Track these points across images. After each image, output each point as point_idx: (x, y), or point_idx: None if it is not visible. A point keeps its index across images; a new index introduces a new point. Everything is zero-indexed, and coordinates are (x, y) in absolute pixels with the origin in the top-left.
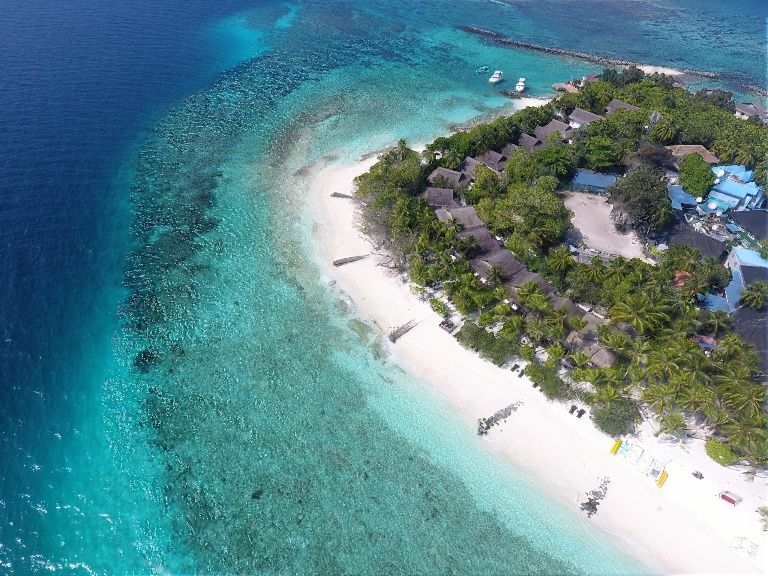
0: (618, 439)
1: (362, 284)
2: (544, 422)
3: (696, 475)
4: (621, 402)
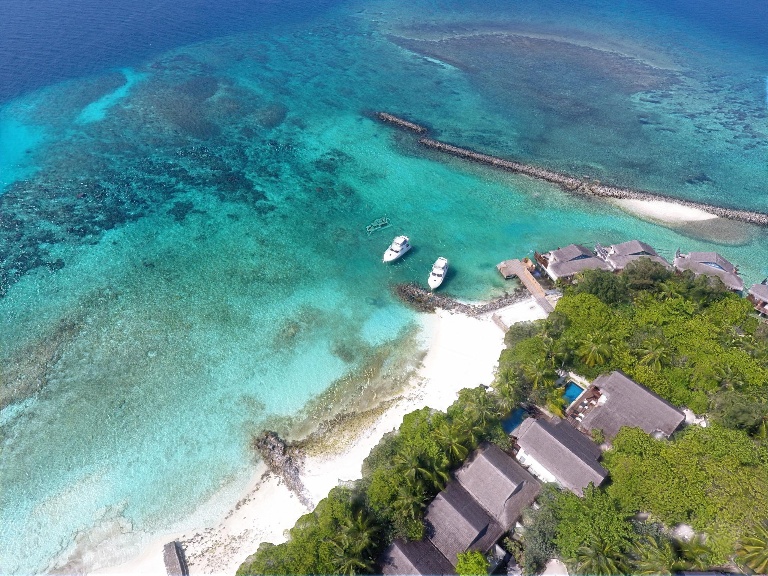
0: None
1: None
2: None
3: None
4: None
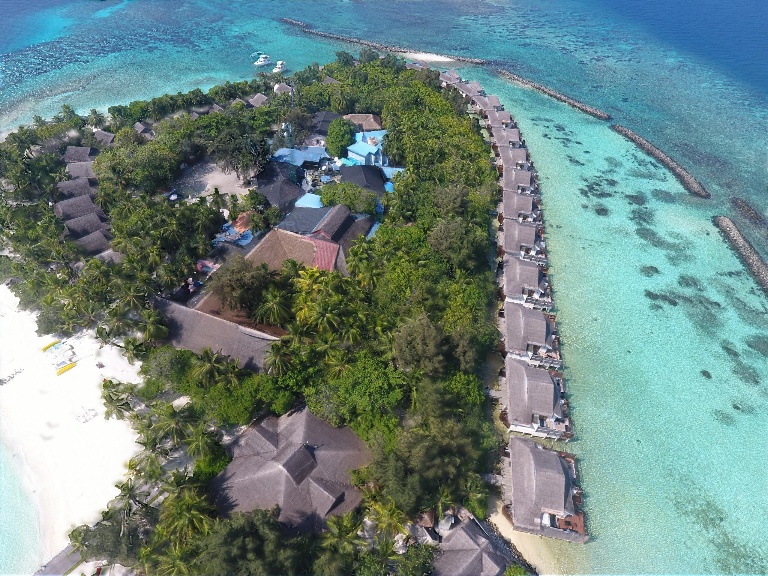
0: (58, 340)
1: None
2: (7, 329)
3: (98, 365)
4: (60, 308)
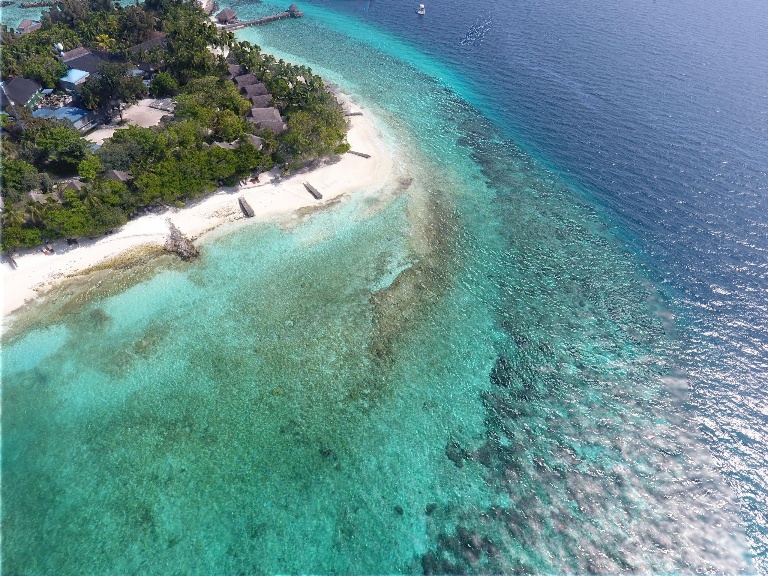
0: None
1: None
2: None
3: None
4: None
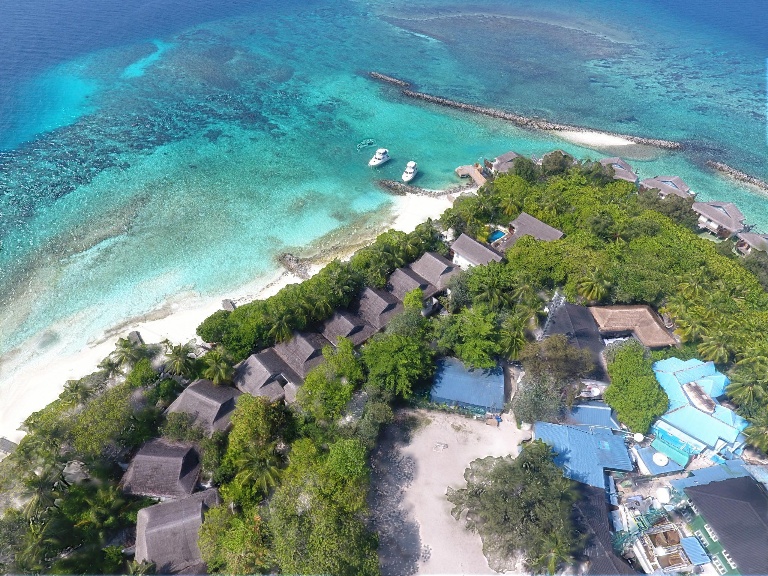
0: None
1: None
2: None
3: None
4: None
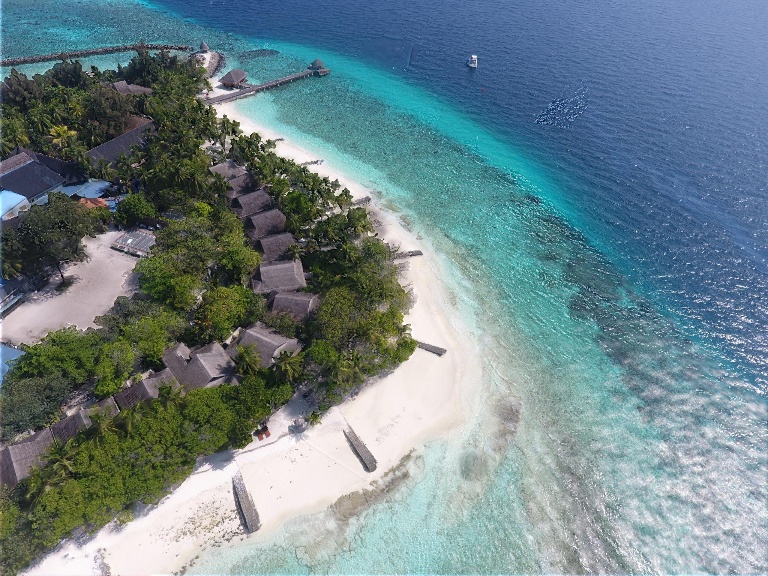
0: None
1: (393, 234)
2: None
3: None
4: None
